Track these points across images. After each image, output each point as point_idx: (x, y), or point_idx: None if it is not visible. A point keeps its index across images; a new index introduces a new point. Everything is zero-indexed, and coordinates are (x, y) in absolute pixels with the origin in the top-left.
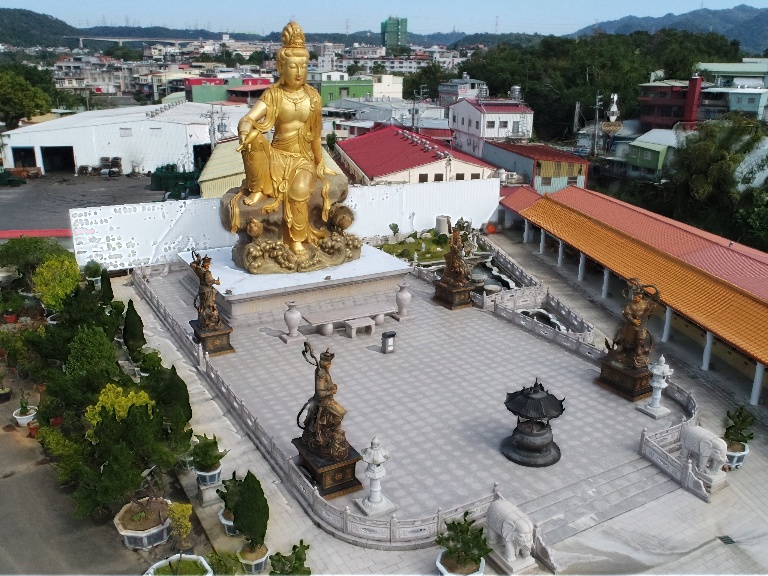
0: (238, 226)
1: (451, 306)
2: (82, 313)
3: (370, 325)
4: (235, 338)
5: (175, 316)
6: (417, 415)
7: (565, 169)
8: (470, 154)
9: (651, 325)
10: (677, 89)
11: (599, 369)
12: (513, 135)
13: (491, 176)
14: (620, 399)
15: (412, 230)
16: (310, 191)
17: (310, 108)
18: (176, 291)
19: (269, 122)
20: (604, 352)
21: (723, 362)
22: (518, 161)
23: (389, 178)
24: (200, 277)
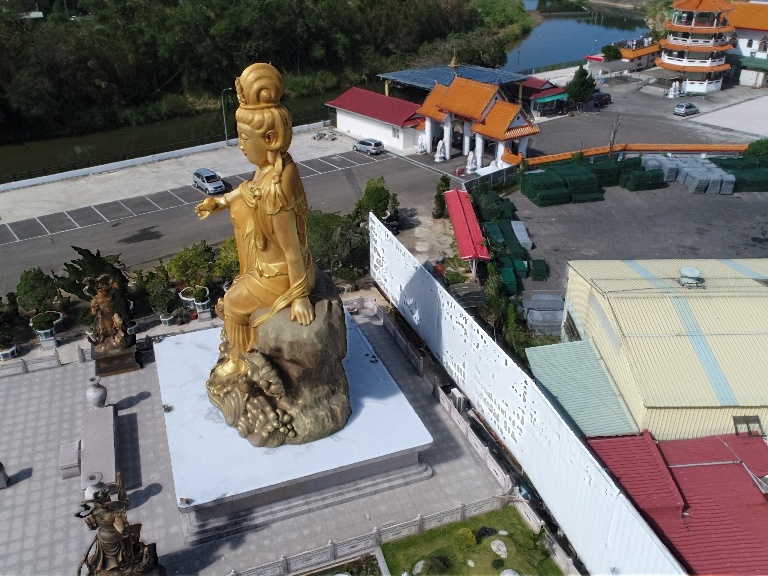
0: None
1: None
2: (84, 267)
3: None
4: (134, 377)
5: None
6: None
7: None
8: None
9: None
10: None
11: None
12: None
13: None
14: None
15: None
16: (234, 309)
17: None
18: None
19: None
20: None
21: None
22: None
23: None
24: None
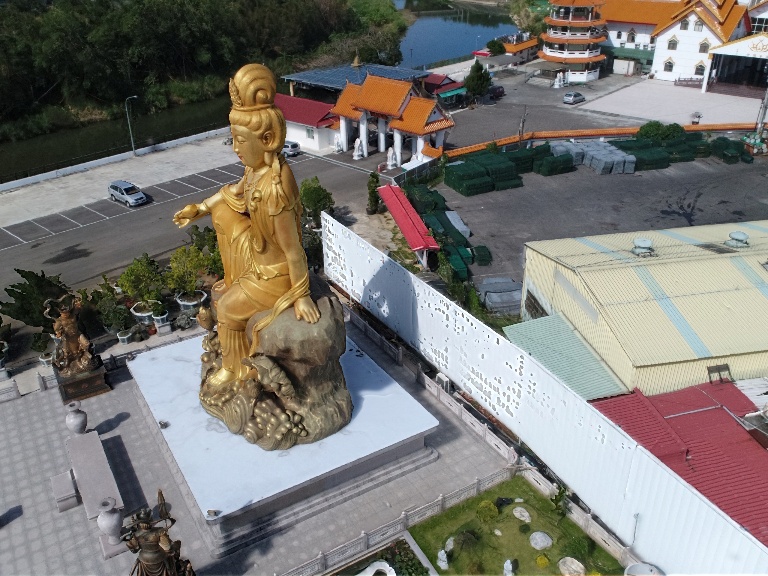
0: None
1: None
2: (29, 290)
3: None
4: (106, 399)
5: None
6: None
7: None
8: None
9: None
10: None
11: None
12: None
13: None
14: None
15: (633, 542)
16: (230, 315)
17: None
18: None
19: None
20: None
21: None
22: None
23: None
24: None
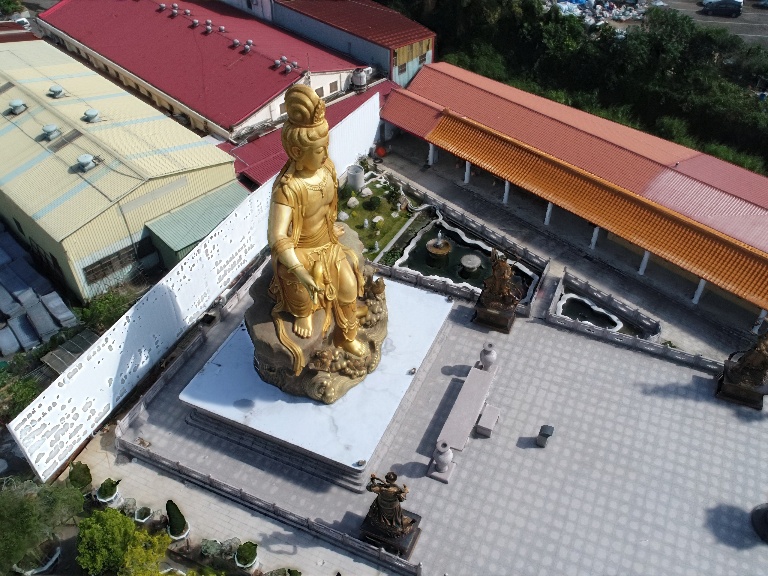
0: (303, 366)
1: (507, 330)
2: None
3: None
4: None
5: (276, 500)
6: (669, 531)
7: (416, 49)
8: (244, 11)
9: (665, 280)
10: None
11: (699, 373)
12: None
13: (349, 80)
14: (752, 411)
15: None
16: None
17: (334, 186)
18: (210, 446)
19: (297, 226)
20: (700, 357)
21: (754, 315)
22: (355, 43)
23: (249, 122)
24: (387, 497)
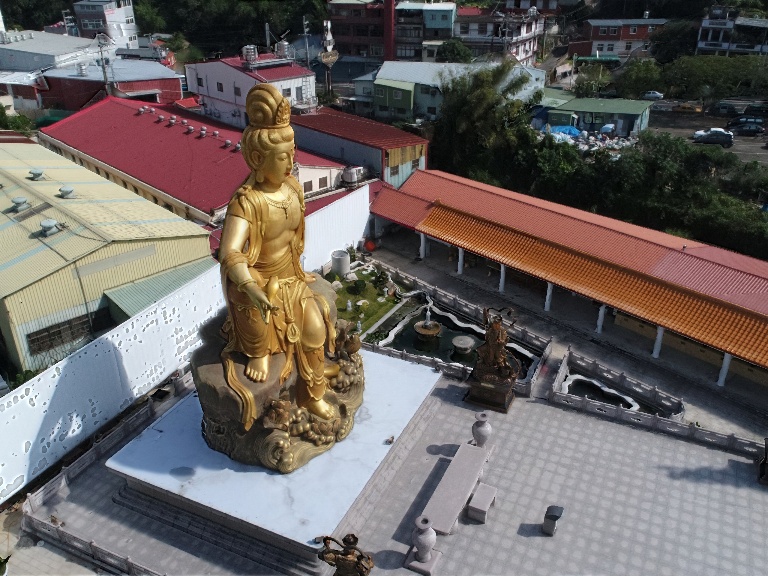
0: (254, 418)
1: (505, 409)
2: None
3: (494, 496)
4: None
5: None
6: None
7: (409, 153)
8: None
9: (683, 363)
10: (369, 6)
11: (735, 457)
12: (298, 103)
13: (339, 177)
14: None
15: None
16: None
17: (301, 209)
18: (137, 528)
19: (254, 246)
20: (734, 437)
21: None
22: (347, 147)
23: None
24: (345, 570)
